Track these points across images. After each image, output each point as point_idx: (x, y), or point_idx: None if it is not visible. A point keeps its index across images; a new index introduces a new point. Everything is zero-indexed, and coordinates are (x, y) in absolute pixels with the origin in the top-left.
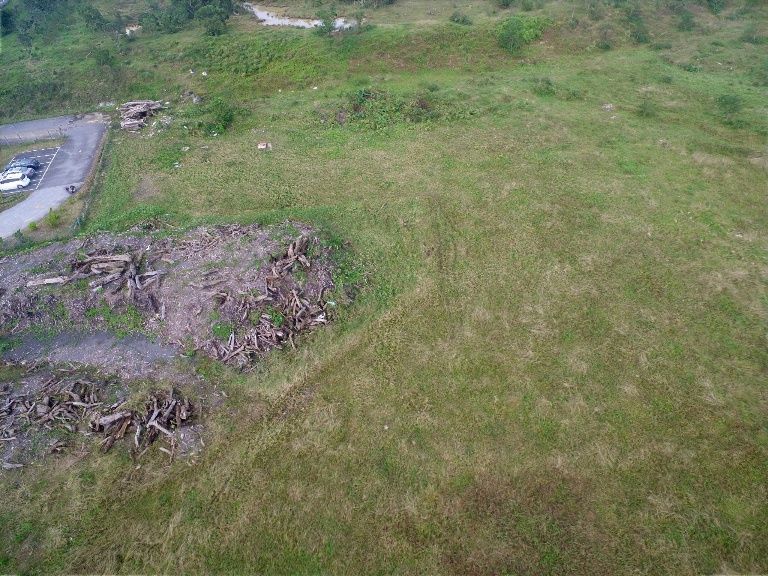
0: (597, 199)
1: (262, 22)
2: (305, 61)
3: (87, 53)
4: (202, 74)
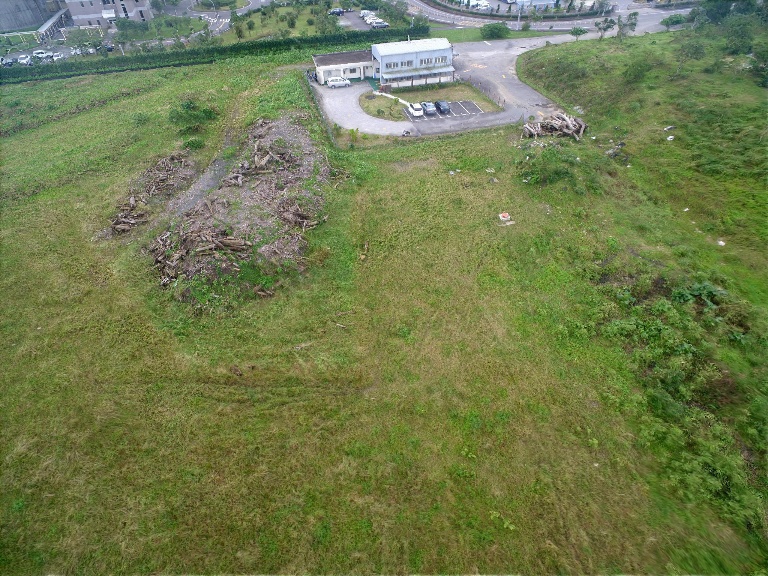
0: None
1: None
2: None
3: (655, 63)
4: (668, 137)
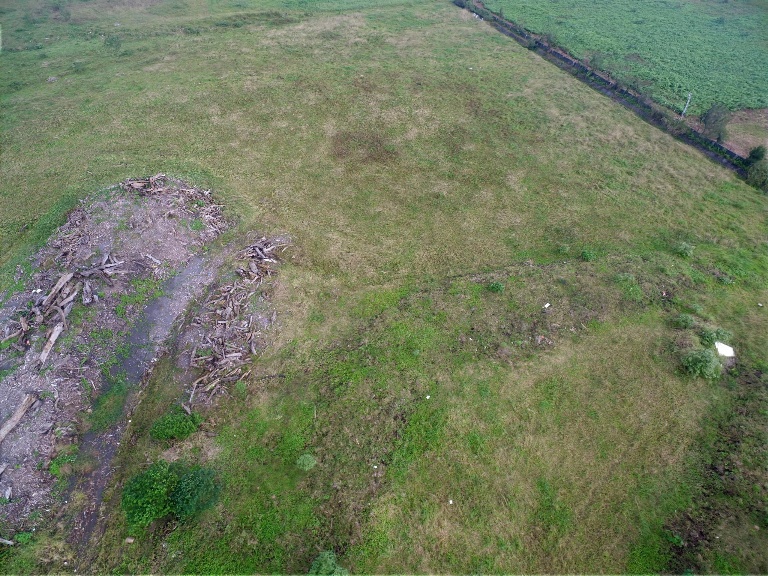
0: (159, 101)
1: None
2: None
3: None
4: None
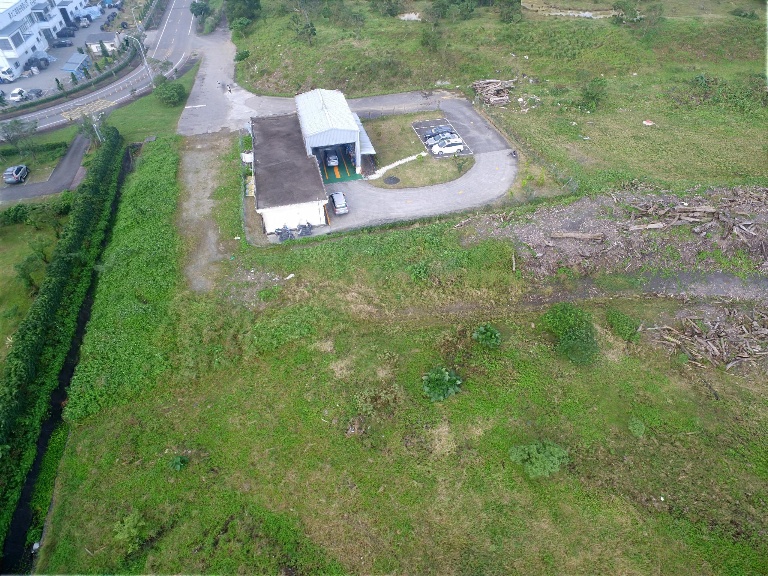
0: None
1: (538, 12)
2: (614, 49)
3: (403, 35)
4: (525, 58)
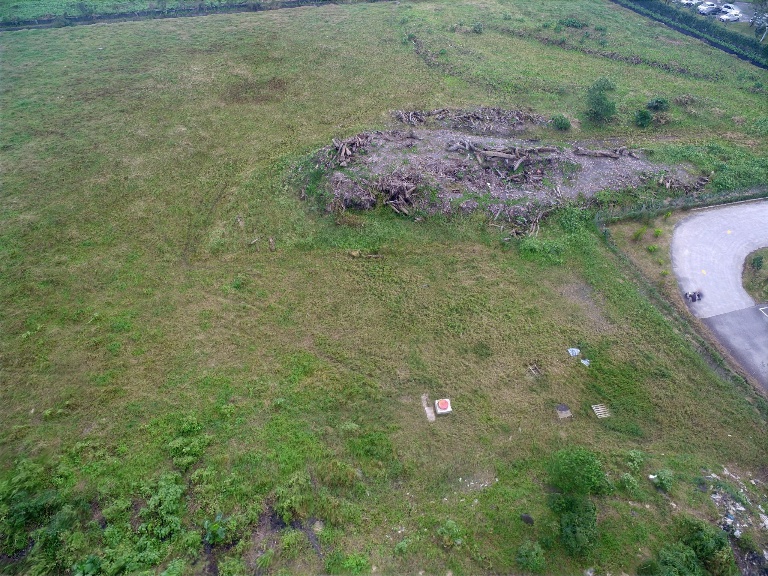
0: (2, 245)
1: None
2: None
3: None
4: None
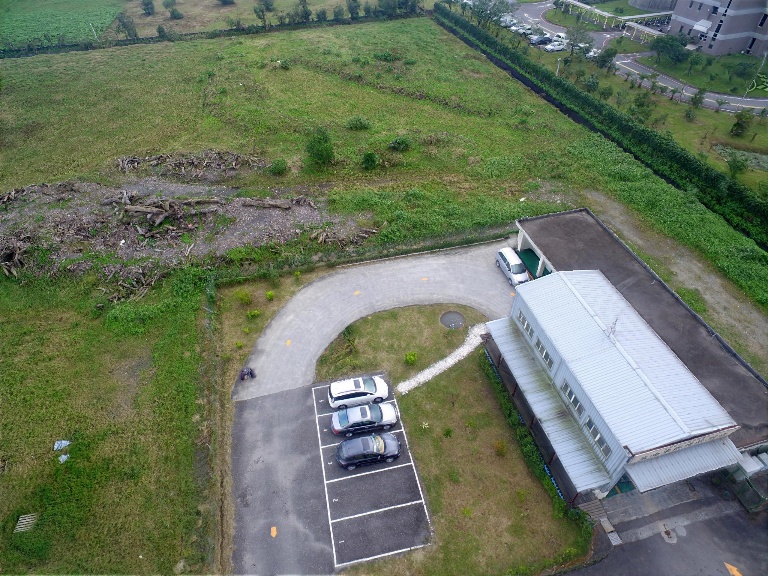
0: None
1: None
2: None
3: None
4: None
